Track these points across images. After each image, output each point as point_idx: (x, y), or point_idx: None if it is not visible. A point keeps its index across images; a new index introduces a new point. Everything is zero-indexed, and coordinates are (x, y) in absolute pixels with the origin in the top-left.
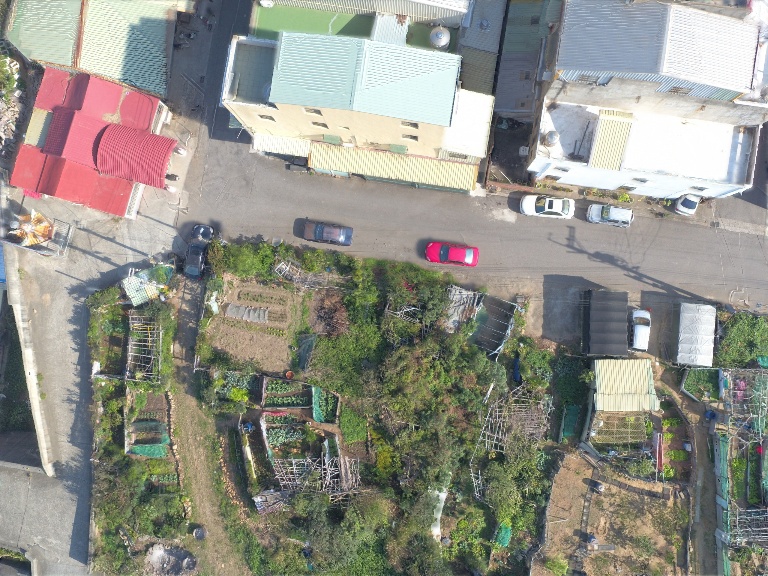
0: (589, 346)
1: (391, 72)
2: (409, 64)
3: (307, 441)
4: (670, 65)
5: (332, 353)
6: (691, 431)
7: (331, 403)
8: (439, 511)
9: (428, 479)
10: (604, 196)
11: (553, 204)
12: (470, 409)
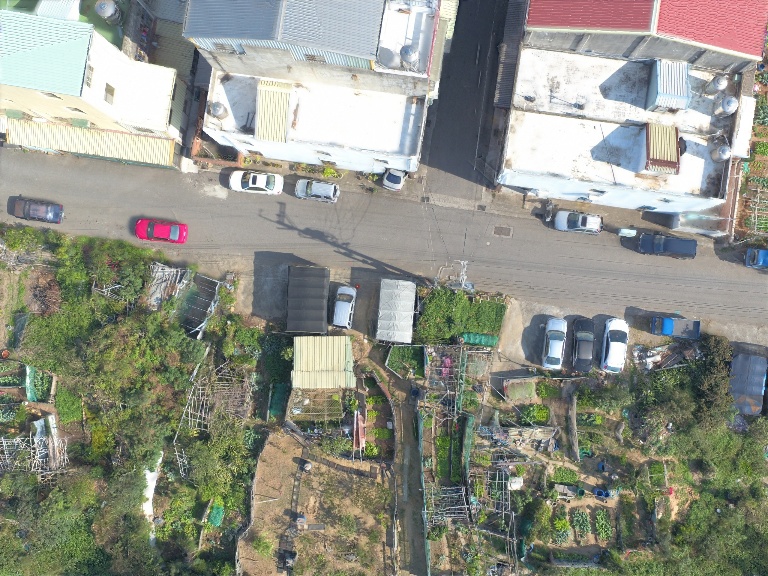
0: (286, 323)
1: (20, 41)
2: (39, 33)
3: (25, 421)
4: (284, 31)
5: (45, 332)
6: (391, 409)
7: (46, 382)
8: (151, 491)
9: (135, 458)
10: (313, 171)
11: (257, 179)
12: (177, 387)
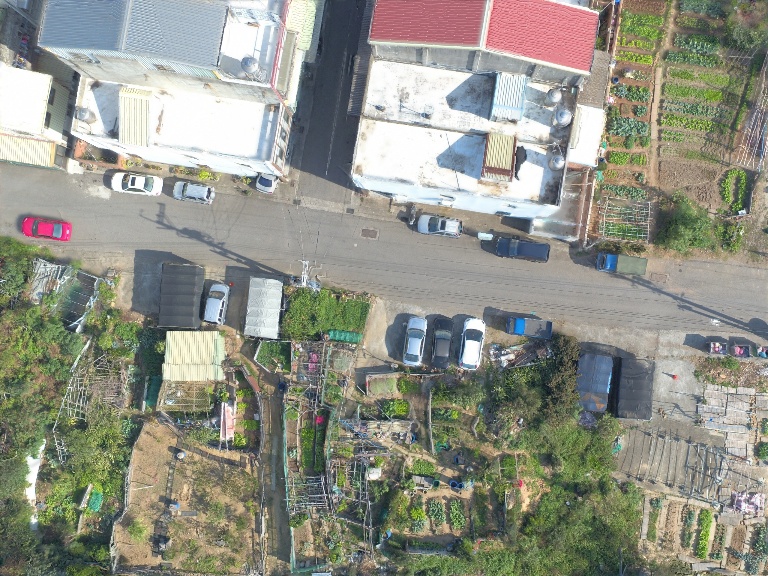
0: (159, 318)
1: None
2: None
3: None
4: (127, 42)
5: None
6: (258, 401)
7: None
8: (33, 476)
9: (17, 445)
10: (191, 174)
11: (135, 181)
12: (58, 378)
